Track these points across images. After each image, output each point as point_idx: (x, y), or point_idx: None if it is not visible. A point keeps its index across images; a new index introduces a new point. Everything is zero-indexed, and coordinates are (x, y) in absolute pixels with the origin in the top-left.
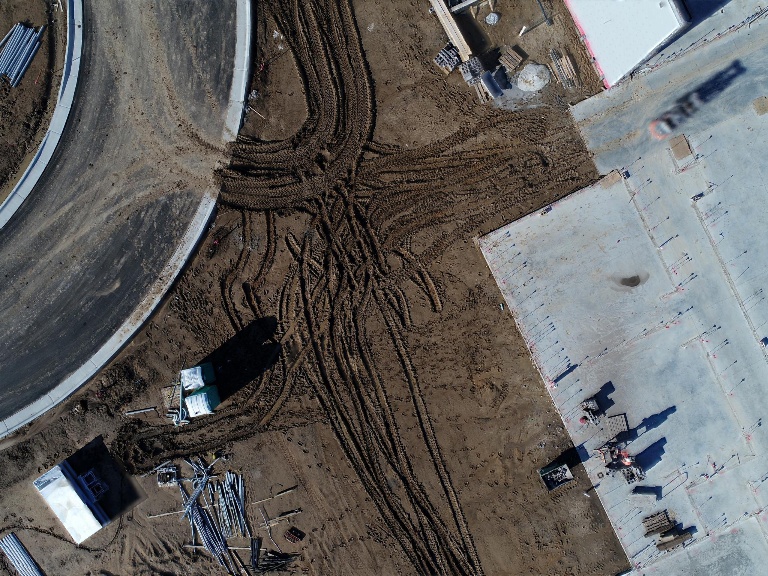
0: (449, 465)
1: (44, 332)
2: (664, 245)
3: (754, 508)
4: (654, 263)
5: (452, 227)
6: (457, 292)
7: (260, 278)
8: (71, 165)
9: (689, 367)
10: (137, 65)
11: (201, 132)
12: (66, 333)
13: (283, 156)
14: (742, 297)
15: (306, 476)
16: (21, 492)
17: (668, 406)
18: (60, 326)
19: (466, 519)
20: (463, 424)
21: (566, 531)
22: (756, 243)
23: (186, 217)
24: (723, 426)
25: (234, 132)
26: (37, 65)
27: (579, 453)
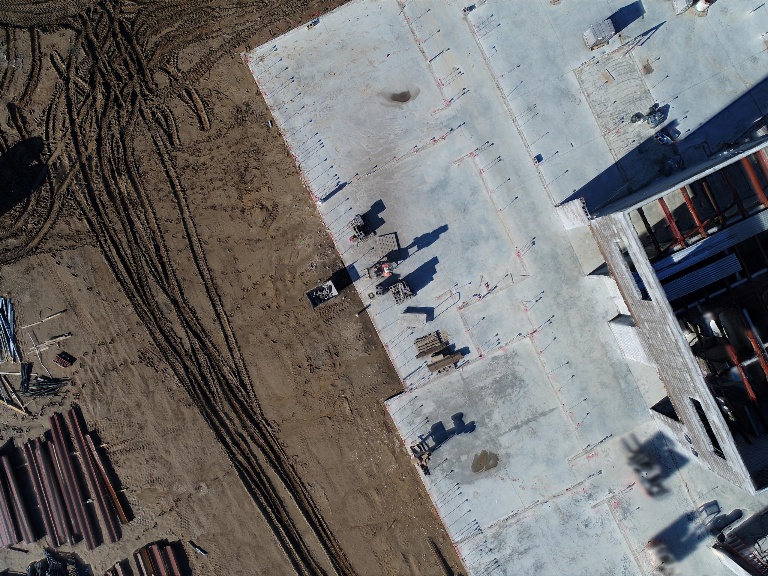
0: (220, 288)
1: None
2: (435, 59)
3: (528, 328)
4: (425, 78)
5: (219, 42)
6: (225, 110)
7: (26, 98)
8: None
9: (461, 185)
10: None
11: None
12: None
13: None
14: (515, 112)
15: (76, 300)
16: None
17: (440, 225)
18: None
19: (238, 343)
20: (234, 246)
21: (338, 353)
22: (530, 57)
23: None
24: (496, 245)
25: None
26: None
27: (349, 273)
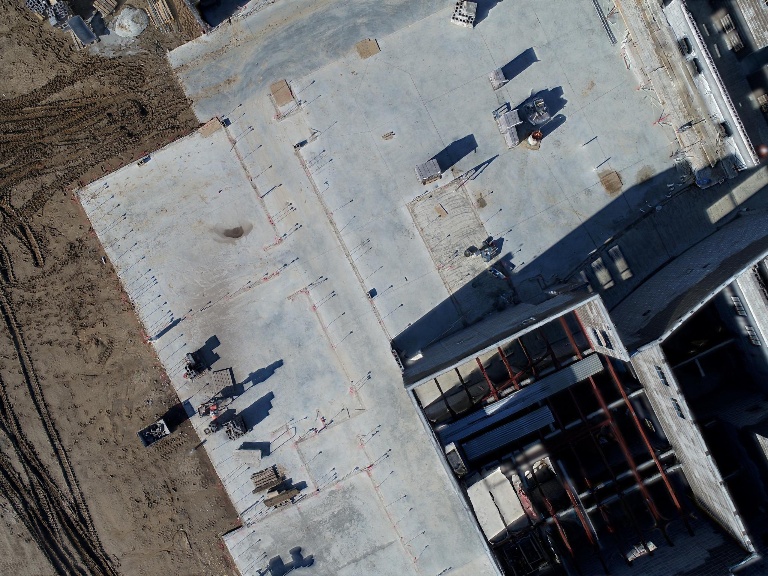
0: (58, 423)
1: None
2: (267, 195)
3: (365, 462)
4: (258, 213)
5: (51, 179)
6: (58, 246)
7: None
8: None
9: (296, 320)
10: None
11: None
12: None
13: None
14: (349, 247)
15: None
16: None
17: (275, 360)
18: None
19: (77, 477)
20: (70, 381)
21: (176, 488)
22: (362, 191)
23: None
24: (332, 379)
25: None
26: None
27: (185, 409)
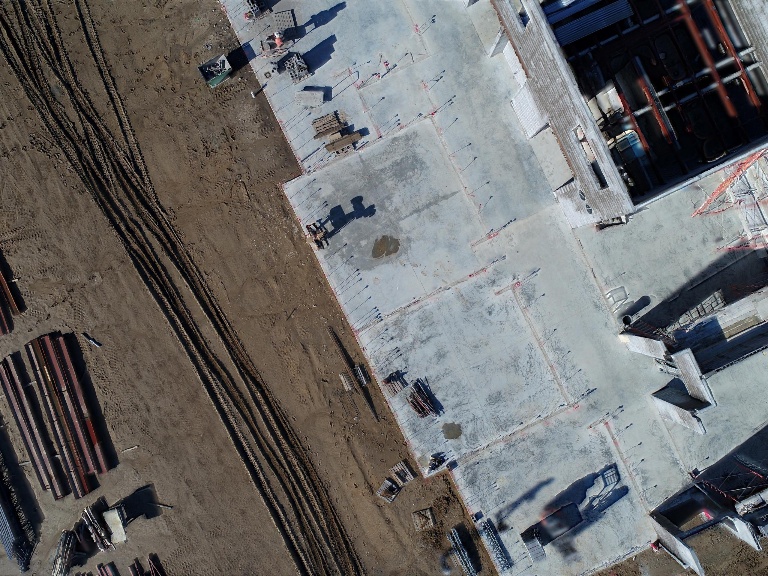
0: (114, 70)
1: None
2: None
3: (428, 109)
4: None
5: None
6: None
7: None
8: None
9: None
10: None
11: None
12: None
13: None
14: None
15: None
16: None
17: (338, 2)
18: None
19: (133, 127)
20: (127, 26)
21: (235, 137)
22: None
23: None
24: (396, 23)
25: None
26: None
27: (245, 52)
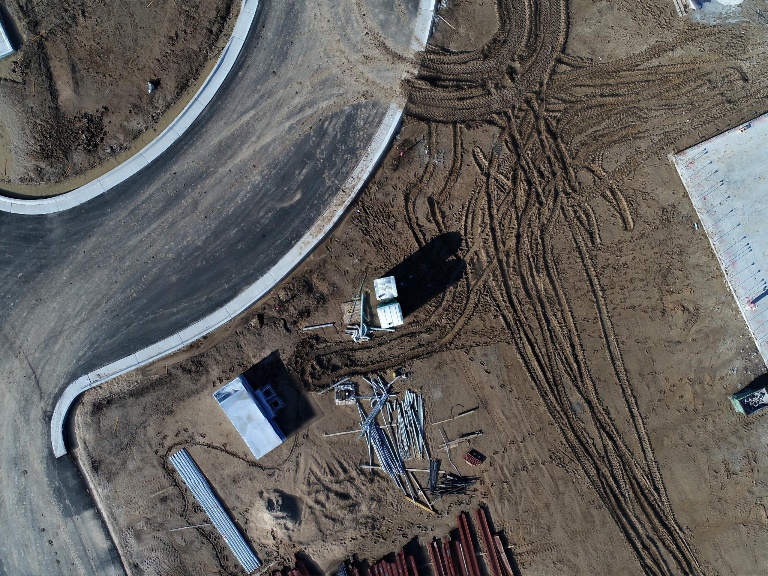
0: (636, 389)
1: (222, 243)
2: None
3: None
4: None
5: (646, 143)
6: (650, 210)
7: (445, 192)
8: (254, 72)
9: None
10: None
11: (388, 41)
12: (244, 244)
13: (471, 68)
14: None
15: (488, 397)
16: (194, 407)
17: None
18: (238, 237)
19: (652, 445)
20: (652, 347)
21: (757, 460)
22: None
23: (370, 128)
24: None
25: (423, 41)
26: None
27: None
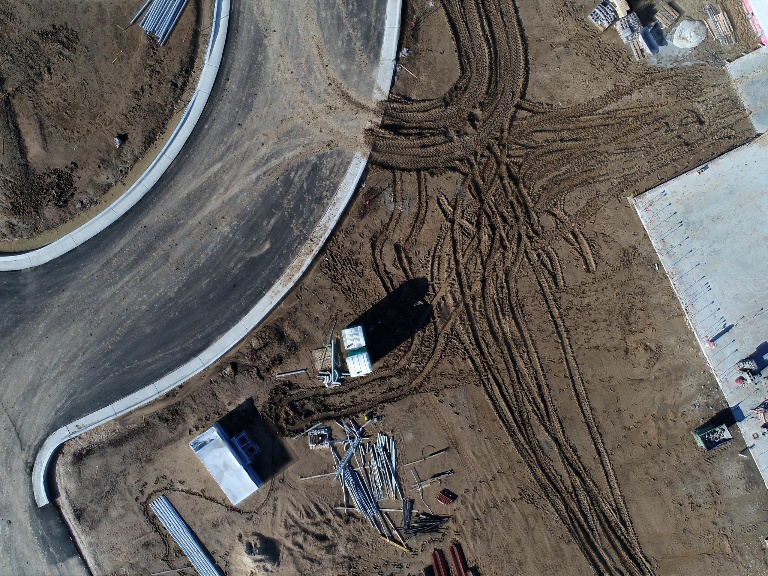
0: (601, 426)
1: (193, 294)
2: None
3: None
4: None
5: (606, 186)
6: (611, 252)
7: (411, 239)
8: (220, 125)
9: None
10: (286, 23)
11: (352, 91)
12: (216, 295)
13: (434, 115)
14: None
15: (458, 438)
16: (172, 454)
17: None
18: (210, 288)
19: (618, 480)
20: (616, 385)
21: (719, 492)
22: None
23: (336, 177)
24: None
25: (385, 91)
26: (185, 23)
27: (734, 413)
